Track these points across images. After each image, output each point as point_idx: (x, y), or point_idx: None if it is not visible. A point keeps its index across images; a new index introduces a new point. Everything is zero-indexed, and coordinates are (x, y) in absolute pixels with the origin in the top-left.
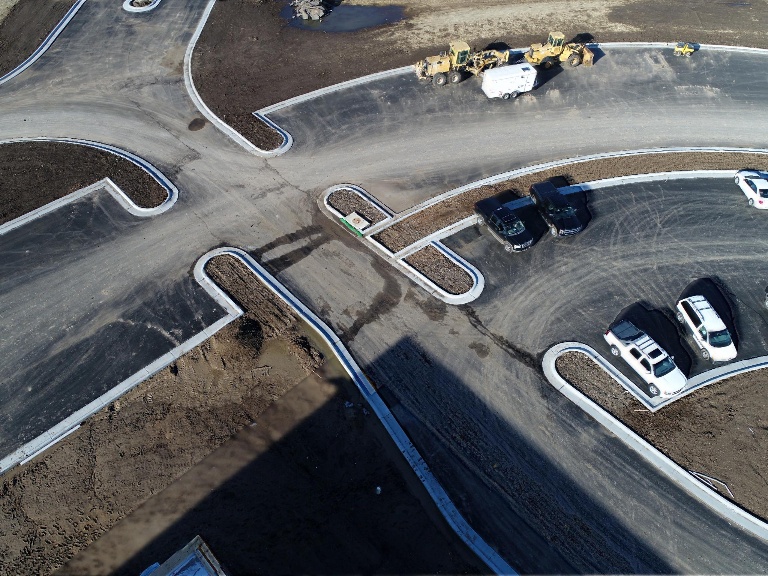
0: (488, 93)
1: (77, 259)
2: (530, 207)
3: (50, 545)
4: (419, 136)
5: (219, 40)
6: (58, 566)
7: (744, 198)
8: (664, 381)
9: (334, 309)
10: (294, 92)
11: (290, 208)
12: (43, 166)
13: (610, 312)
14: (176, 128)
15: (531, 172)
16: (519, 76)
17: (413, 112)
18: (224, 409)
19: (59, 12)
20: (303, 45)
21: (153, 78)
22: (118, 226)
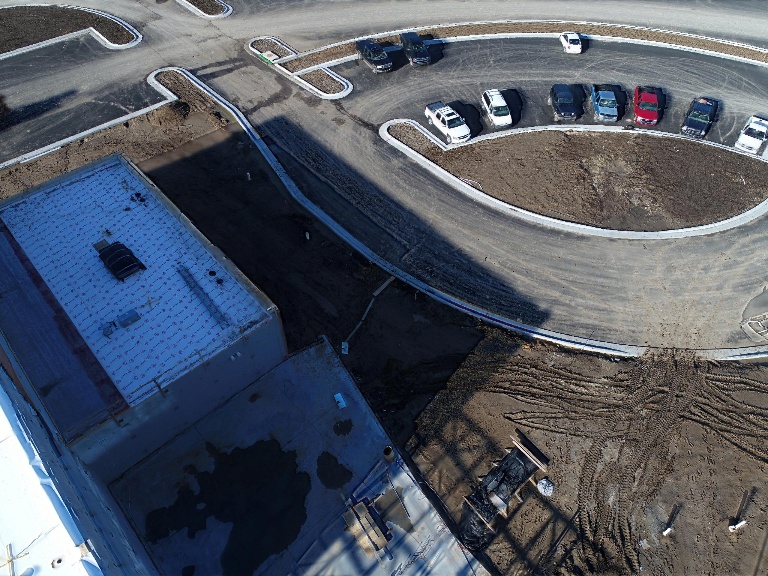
0: None
1: (66, 70)
2: (400, 51)
3: None
4: (329, 10)
5: None
6: None
7: (562, 49)
8: (453, 130)
9: (242, 99)
10: None
11: (223, 48)
12: (45, 20)
13: None
14: (146, 2)
15: (407, 32)
16: None
17: None
18: (157, 143)
19: None
20: None
21: None
22: (97, 54)
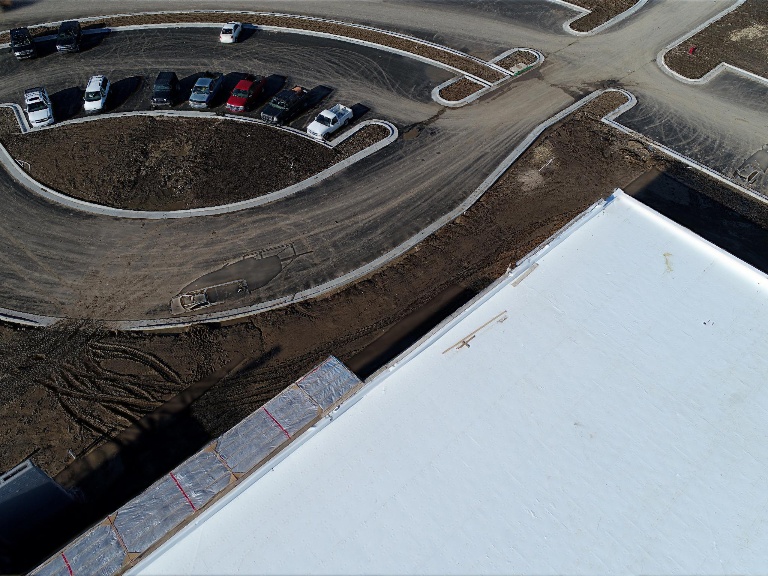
0: None
1: None
2: None
3: None
4: None
5: None
6: None
7: None
8: (31, 114)
9: None
10: None
11: None
12: None
13: (53, 90)
14: None
15: (84, 20)
16: None
17: None
18: None
19: None
20: None
21: None
22: None
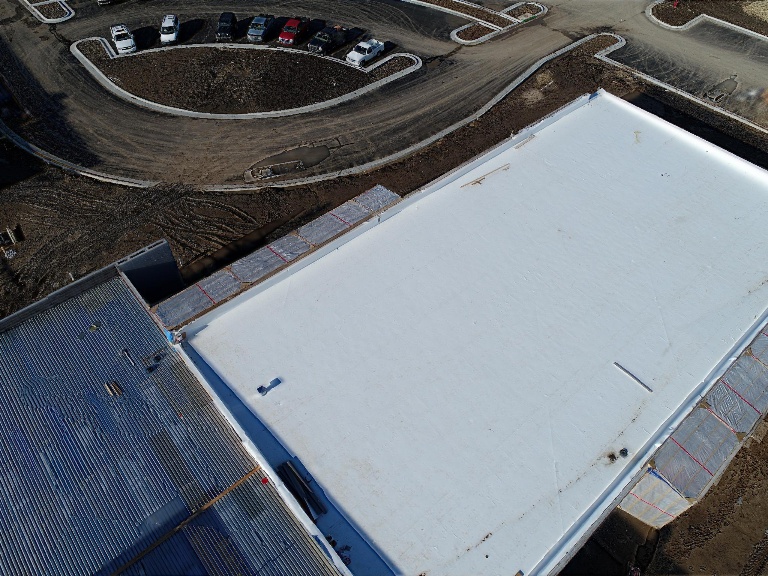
0: None
1: None
2: None
3: None
4: None
5: None
6: None
7: None
8: (119, 43)
9: None
10: None
11: None
12: None
13: (132, 28)
14: None
15: None
16: None
17: None
18: None
19: None
20: None
21: None
22: None
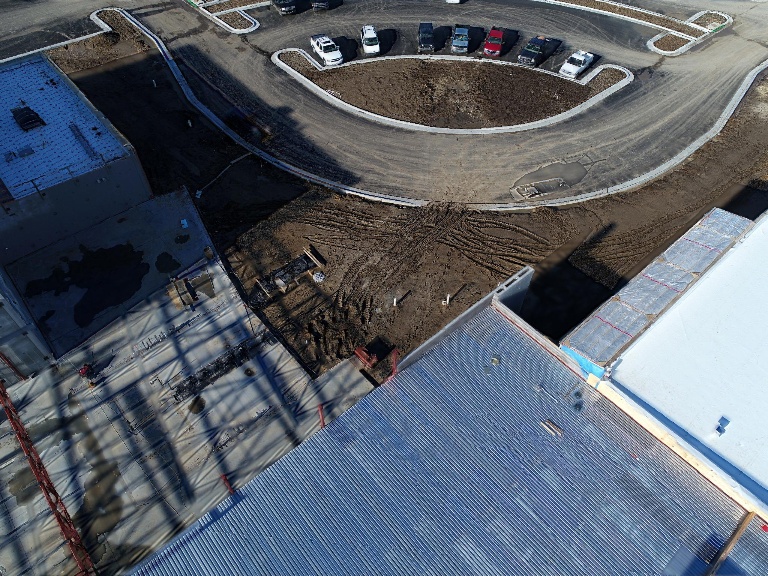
0: None
1: (24, 8)
2: None
3: None
4: None
5: None
6: None
7: None
8: (327, 54)
9: (165, 32)
10: None
11: None
12: None
13: None
14: None
15: None
16: None
17: None
18: (88, 60)
19: None
20: None
21: None
22: None
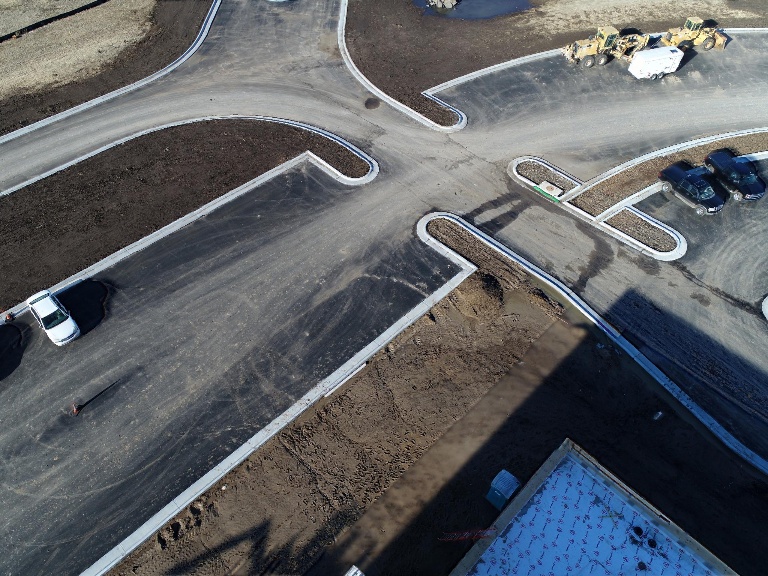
0: (637, 74)
1: (307, 223)
2: (706, 176)
3: (381, 462)
4: (582, 113)
5: (366, 27)
6: (395, 479)
7: None
8: None
9: (557, 265)
10: (453, 74)
11: (484, 178)
12: (246, 141)
13: None
14: (354, 107)
15: (697, 145)
16: (668, 58)
17: (570, 92)
18: (490, 350)
19: (205, 2)
20: (446, 31)
21: (316, 62)
22: (333, 194)
